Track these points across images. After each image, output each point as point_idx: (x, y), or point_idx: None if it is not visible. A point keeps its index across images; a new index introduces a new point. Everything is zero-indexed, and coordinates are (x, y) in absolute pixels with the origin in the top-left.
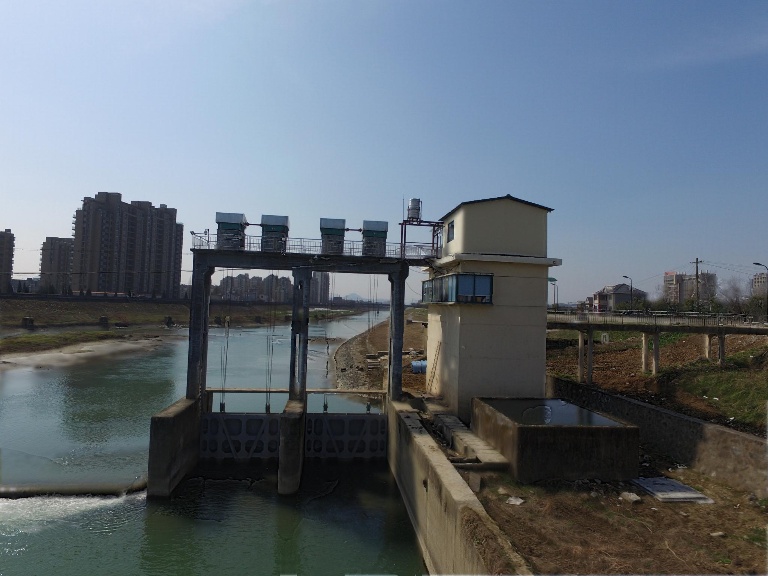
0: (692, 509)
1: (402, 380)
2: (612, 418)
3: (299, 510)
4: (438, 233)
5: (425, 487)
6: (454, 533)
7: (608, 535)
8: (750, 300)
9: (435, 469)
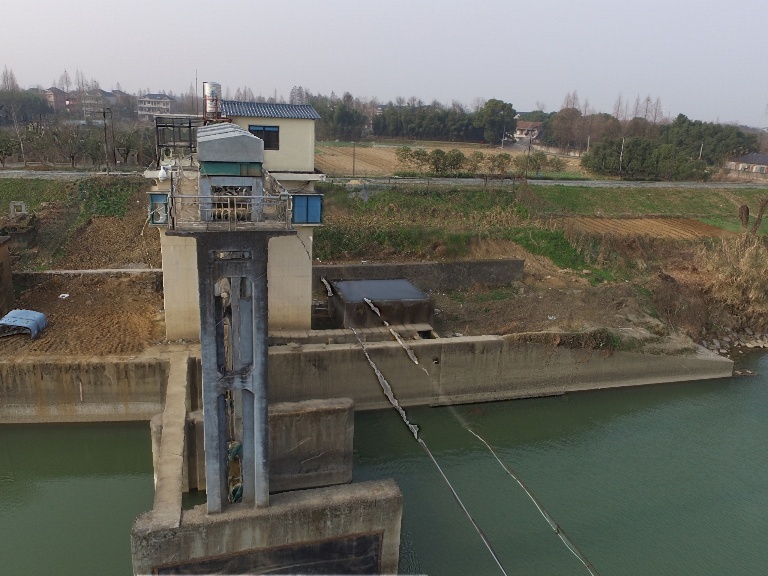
0: (437, 304)
1: (90, 348)
2: (390, 278)
3: (354, 481)
4: (195, 126)
5: (438, 361)
6: (500, 354)
7: (476, 324)
8: (84, 142)
9: (456, 342)
